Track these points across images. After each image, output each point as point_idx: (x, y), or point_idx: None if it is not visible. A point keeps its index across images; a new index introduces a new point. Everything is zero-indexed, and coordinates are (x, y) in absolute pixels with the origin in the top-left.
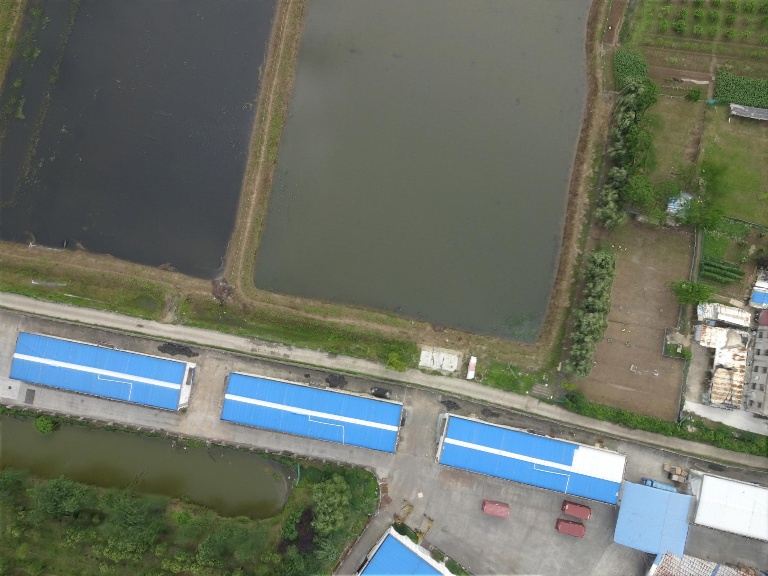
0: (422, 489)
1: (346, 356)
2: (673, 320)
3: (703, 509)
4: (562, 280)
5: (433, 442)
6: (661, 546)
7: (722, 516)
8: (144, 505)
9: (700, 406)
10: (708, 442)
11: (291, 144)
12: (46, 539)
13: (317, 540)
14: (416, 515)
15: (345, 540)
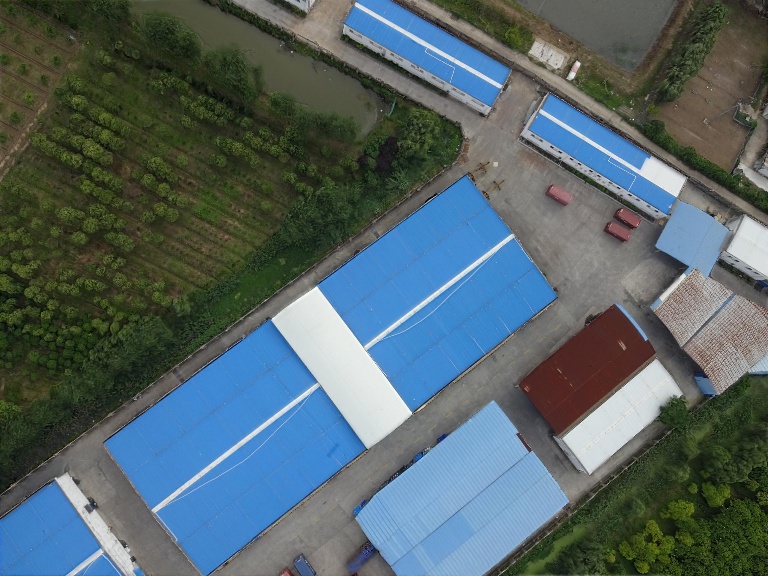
0: (499, 159)
1: (467, 22)
2: (749, 94)
3: (736, 242)
4: (671, 26)
5: (521, 122)
6: (694, 261)
7: (750, 252)
8: (252, 66)
9: (751, 171)
10: (750, 200)
11: None
12: (130, 85)
13: (396, 164)
14: (487, 180)
15: (417, 179)
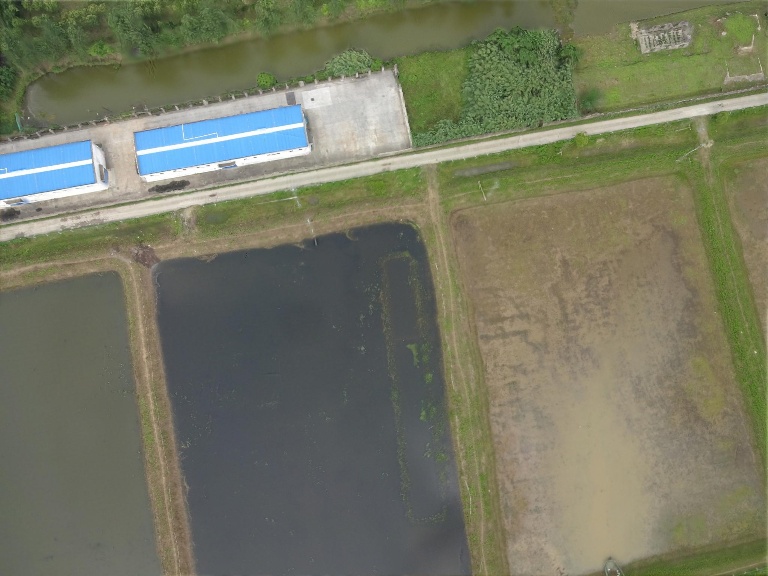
0: None
1: None
2: None
3: None
4: None
5: None
6: None
7: None
8: (126, 44)
9: None
10: None
11: (128, 422)
12: None
13: None
14: None
15: None
